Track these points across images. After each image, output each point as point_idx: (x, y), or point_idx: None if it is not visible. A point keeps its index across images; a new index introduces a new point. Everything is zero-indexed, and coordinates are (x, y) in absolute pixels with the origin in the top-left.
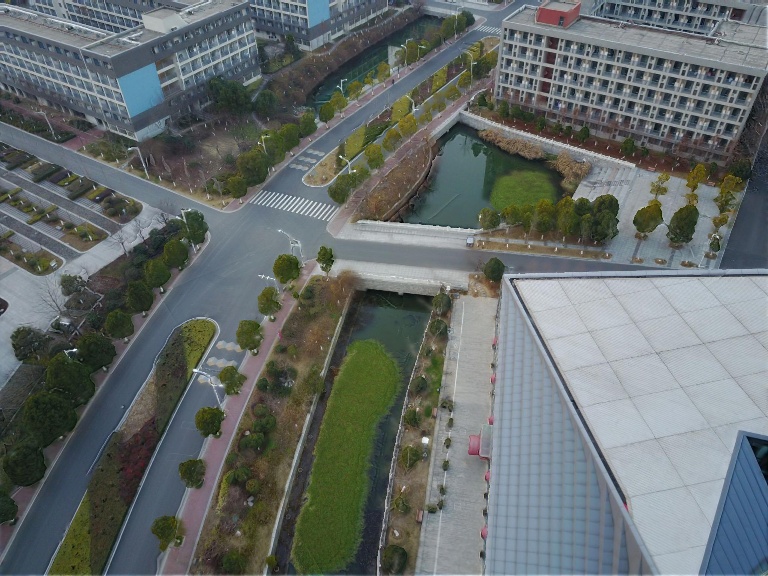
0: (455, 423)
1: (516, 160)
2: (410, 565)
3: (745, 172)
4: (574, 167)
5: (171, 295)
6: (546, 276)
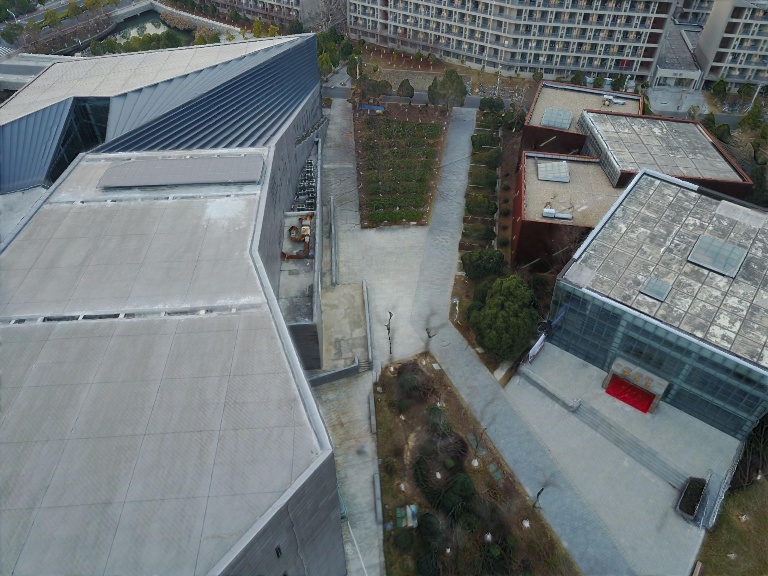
0: None
1: (175, 32)
2: None
3: (294, 28)
4: (201, 31)
5: None
6: (75, 60)
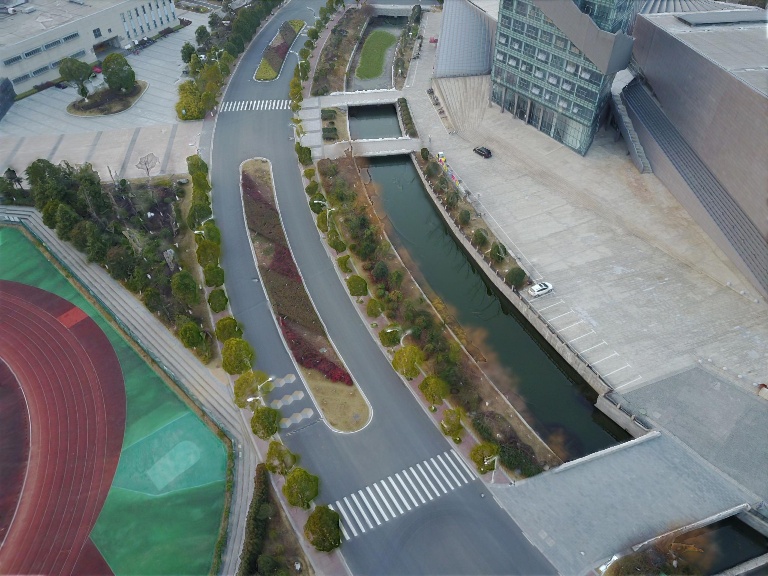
0: (424, 42)
1: None
2: (406, 69)
3: None
4: None
5: (277, 15)
6: None
